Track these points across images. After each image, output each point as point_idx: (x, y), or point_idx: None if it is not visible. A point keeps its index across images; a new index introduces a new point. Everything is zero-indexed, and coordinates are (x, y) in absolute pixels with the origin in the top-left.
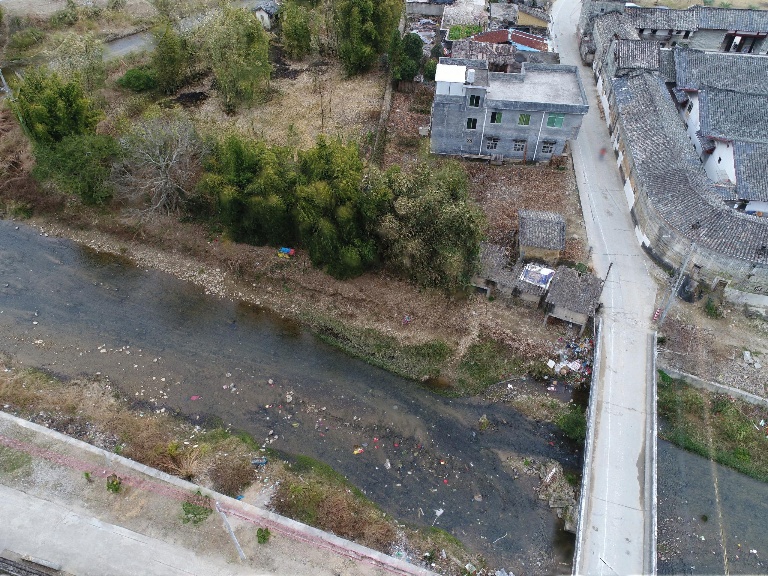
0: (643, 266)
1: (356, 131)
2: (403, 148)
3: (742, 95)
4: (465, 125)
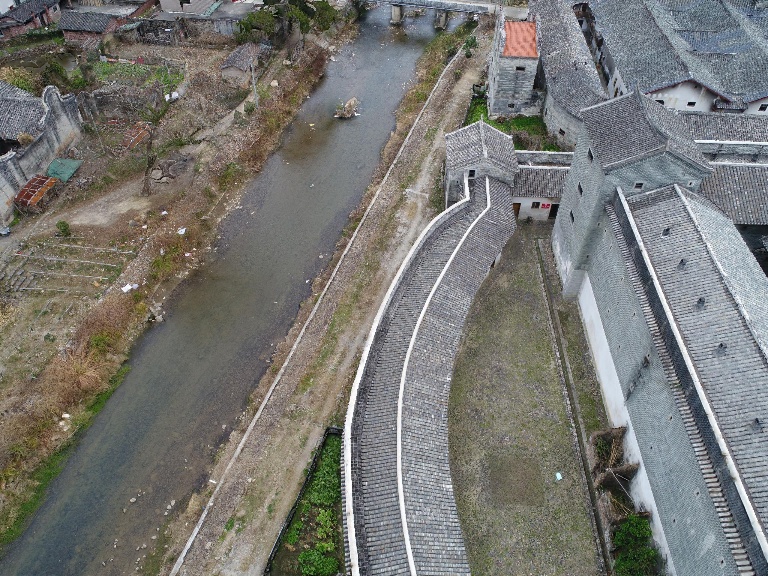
0: None
1: None
2: None
3: (722, 7)
4: None
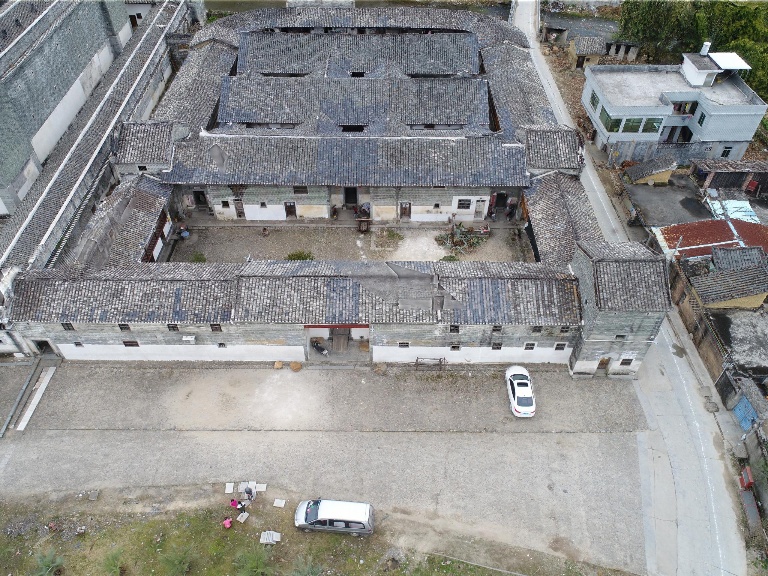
0: None
1: None
2: None
3: None
4: None
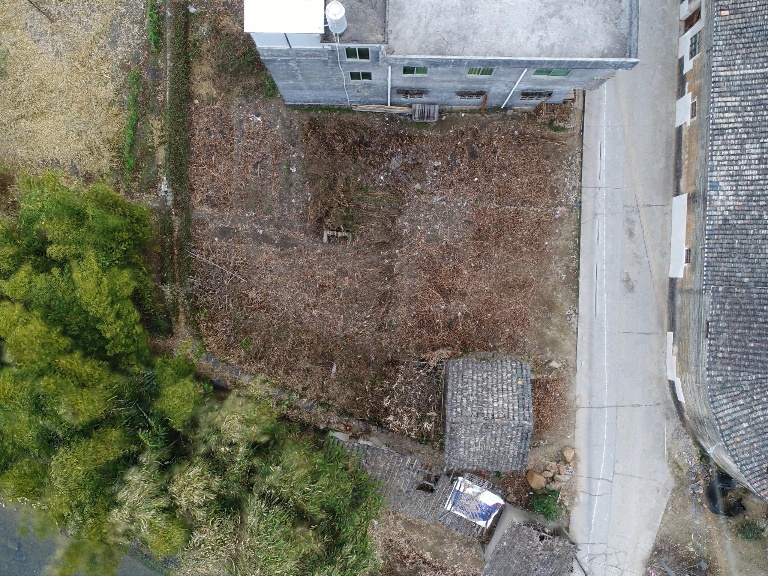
0: (660, 434)
1: (124, 2)
2: (228, 83)
3: None
4: (346, 78)
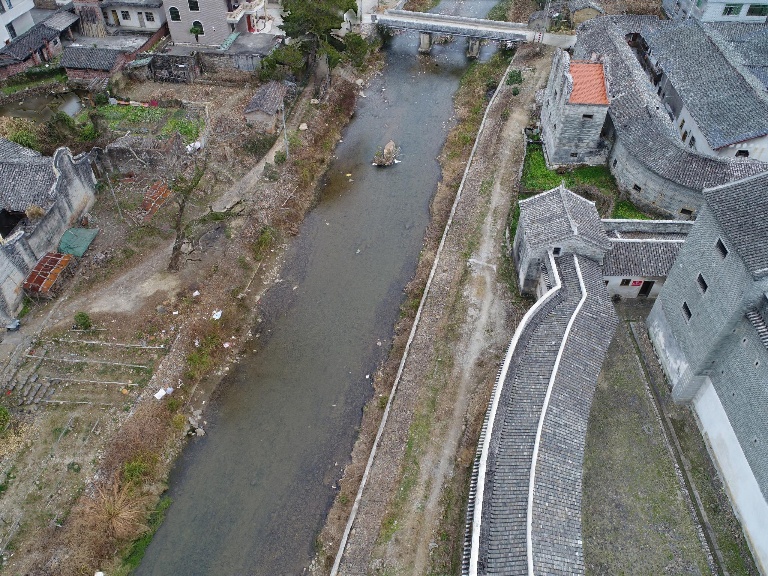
0: None
1: None
2: (662, 1)
3: None
4: None
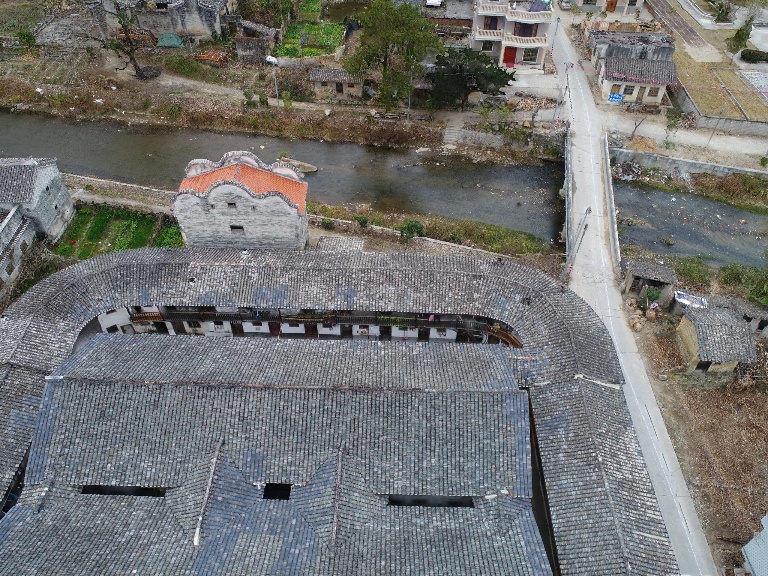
0: None
1: None
2: None
3: None
4: None
